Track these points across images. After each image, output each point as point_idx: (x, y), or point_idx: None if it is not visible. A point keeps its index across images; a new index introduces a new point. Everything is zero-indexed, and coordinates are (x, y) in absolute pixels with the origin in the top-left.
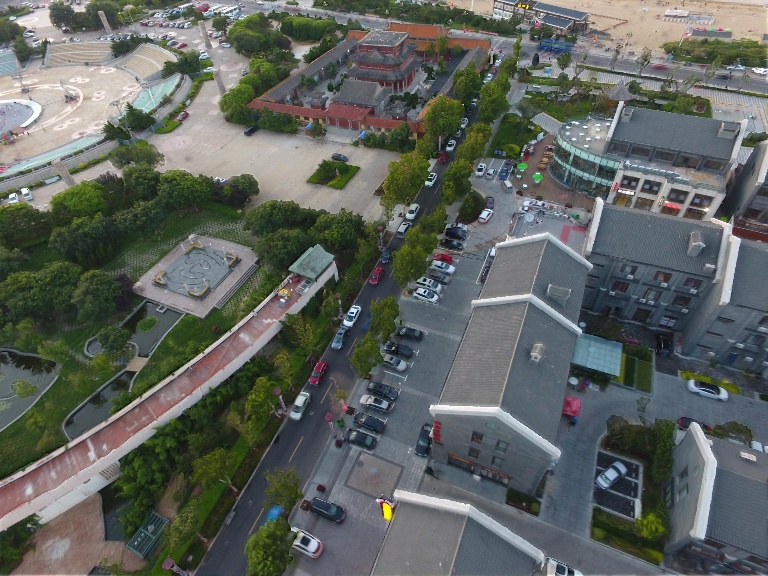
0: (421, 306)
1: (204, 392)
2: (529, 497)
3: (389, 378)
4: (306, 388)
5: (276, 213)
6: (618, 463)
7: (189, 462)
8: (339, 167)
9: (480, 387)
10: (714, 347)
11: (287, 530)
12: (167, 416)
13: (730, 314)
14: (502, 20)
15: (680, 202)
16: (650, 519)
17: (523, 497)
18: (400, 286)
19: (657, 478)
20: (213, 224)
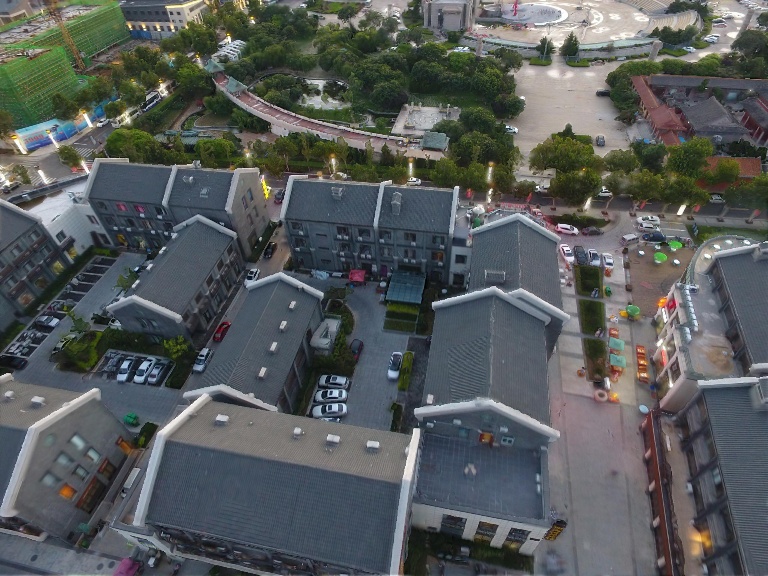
0: None
1: None
2: (292, 264)
3: None
4: None
5: (474, 115)
6: None
7: None
8: (578, 139)
9: None
10: None
11: None
12: (316, 133)
13: None
14: None
15: None
16: None
17: None
18: (431, 182)
19: None
20: None
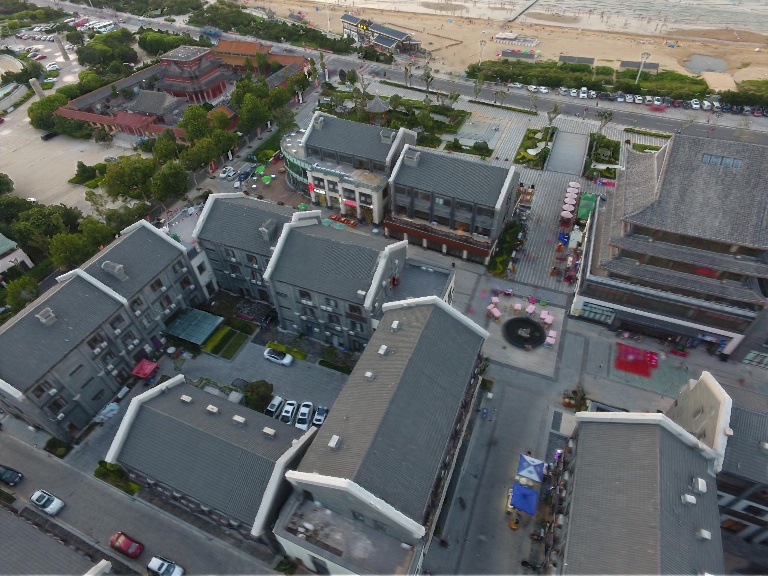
0: None
1: None
2: (63, 443)
3: None
4: None
5: None
6: None
7: None
8: (99, 168)
9: None
10: (294, 320)
11: None
12: None
13: (281, 289)
14: (341, 39)
15: (353, 200)
16: None
17: (58, 443)
18: (61, 270)
19: None
20: None
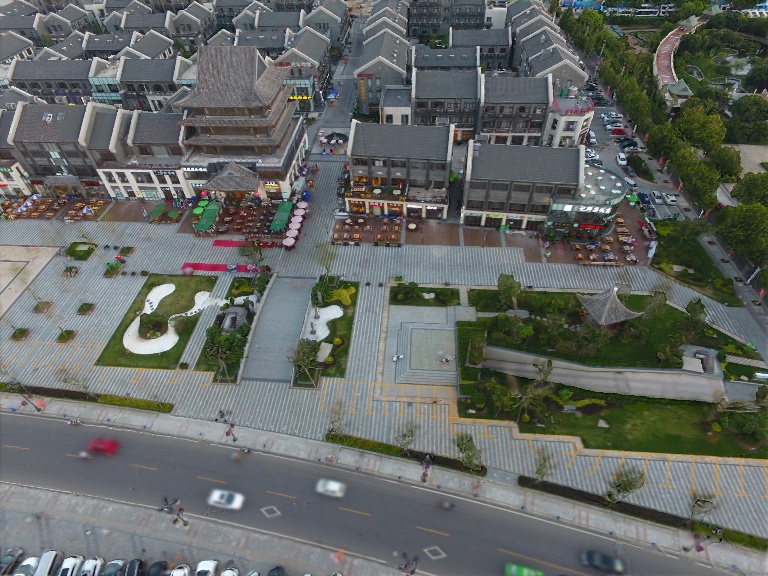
0: None
1: None
2: None
3: None
4: None
5: None
6: None
7: None
8: None
9: None
10: None
11: None
12: None
13: None
14: None
15: None
16: None
17: None
18: None
19: None
20: None
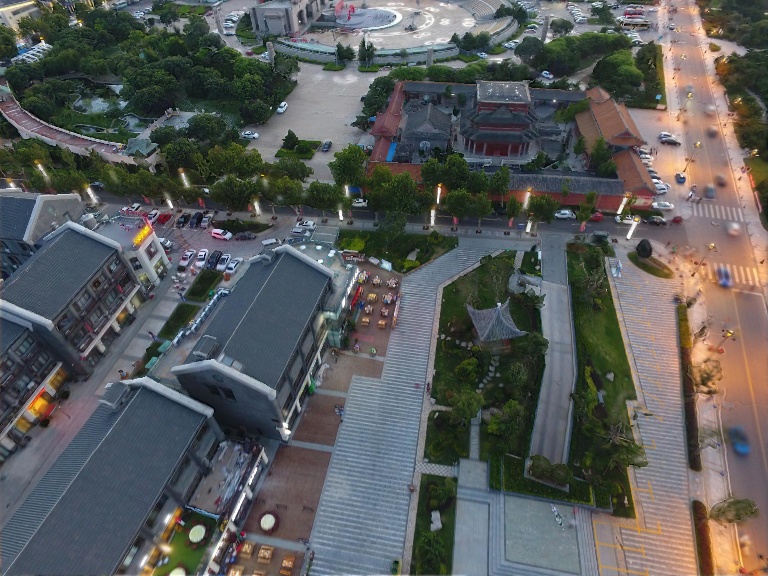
0: None
1: None
2: None
3: None
4: None
5: (195, 121)
6: None
7: None
8: (299, 145)
9: None
10: None
11: None
12: (45, 139)
13: None
14: None
15: None
16: None
17: None
18: None
19: None
20: (234, 119)
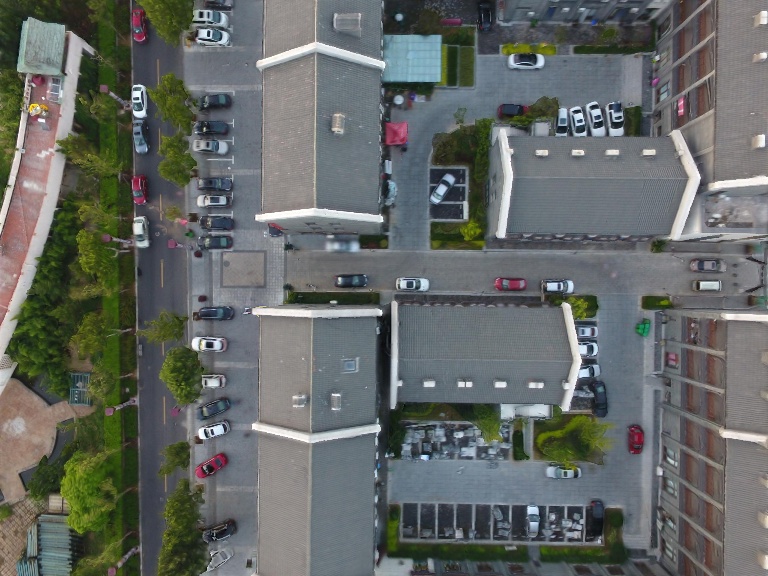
0: (213, 55)
1: (34, 263)
2: (377, 237)
3: (216, 166)
4: (137, 210)
5: None
6: (447, 176)
7: (70, 330)
8: None
9: (294, 184)
10: (533, 6)
11: (187, 353)
12: (15, 302)
13: None
14: None
15: None
16: (469, 228)
17: (372, 238)
18: (172, 44)
19: (478, 180)
20: None
